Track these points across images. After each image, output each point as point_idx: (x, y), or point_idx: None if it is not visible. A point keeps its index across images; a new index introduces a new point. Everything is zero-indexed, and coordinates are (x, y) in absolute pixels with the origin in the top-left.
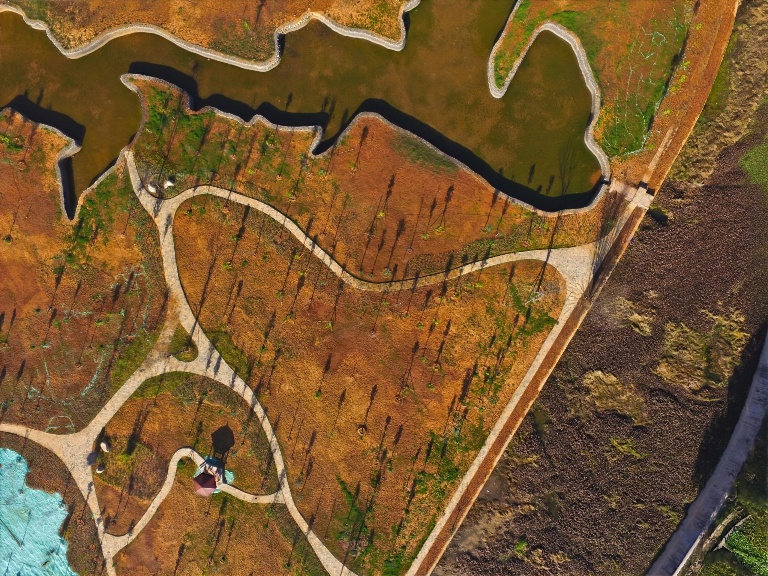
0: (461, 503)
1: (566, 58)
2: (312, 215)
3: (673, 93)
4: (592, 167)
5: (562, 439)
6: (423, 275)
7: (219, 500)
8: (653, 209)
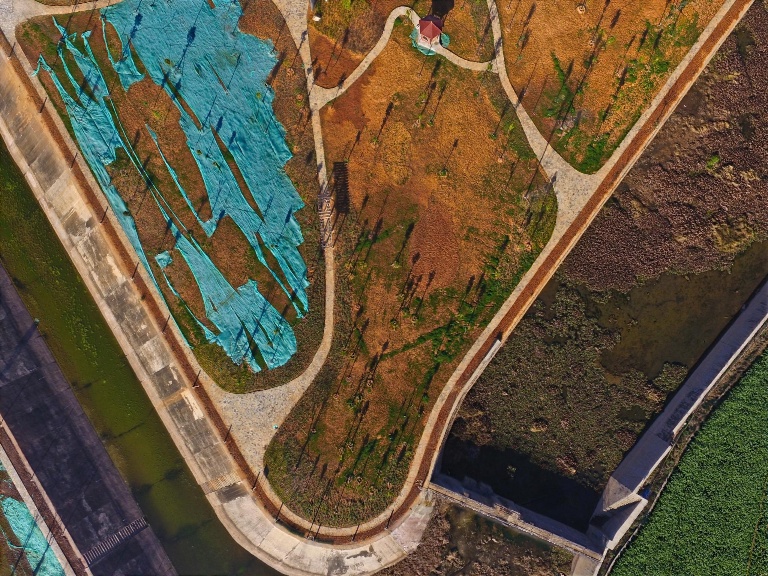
0: (668, 97)
1: None
2: None
3: None
4: None
5: (764, 60)
6: None
7: (433, 62)
8: None
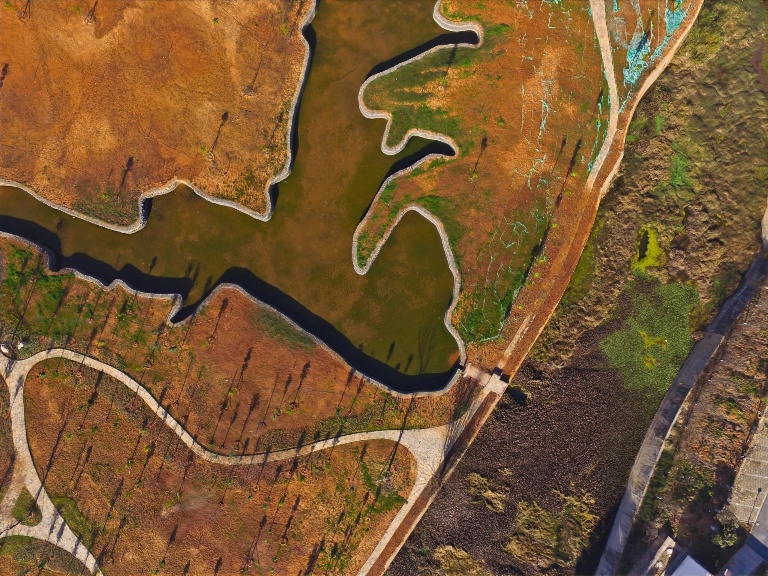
0: None
1: (431, 239)
2: (166, 384)
3: (532, 282)
4: (451, 348)
5: None
6: (274, 450)
7: None
8: (513, 387)
